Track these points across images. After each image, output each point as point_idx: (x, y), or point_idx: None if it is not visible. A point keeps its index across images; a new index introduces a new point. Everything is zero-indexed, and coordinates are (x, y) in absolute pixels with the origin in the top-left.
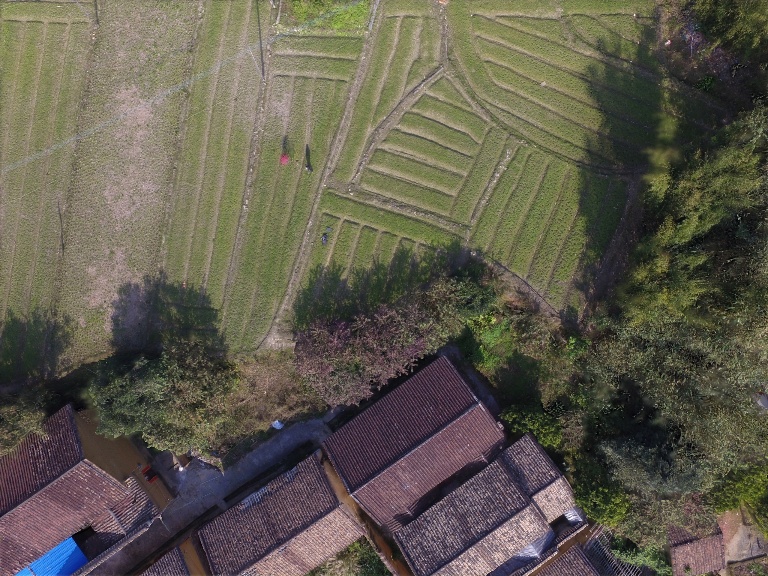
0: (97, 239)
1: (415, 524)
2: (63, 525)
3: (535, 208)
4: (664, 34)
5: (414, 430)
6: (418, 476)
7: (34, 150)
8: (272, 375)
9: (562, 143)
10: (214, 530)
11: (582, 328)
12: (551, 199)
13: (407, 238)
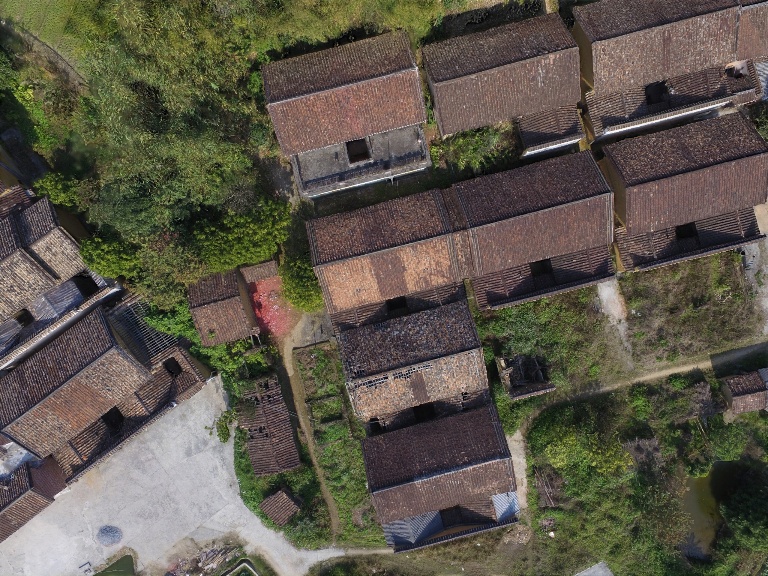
0: None
1: None
2: None
3: None
4: None
5: None
6: None
7: None
8: None
9: None
10: None
11: None
12: None
13: None
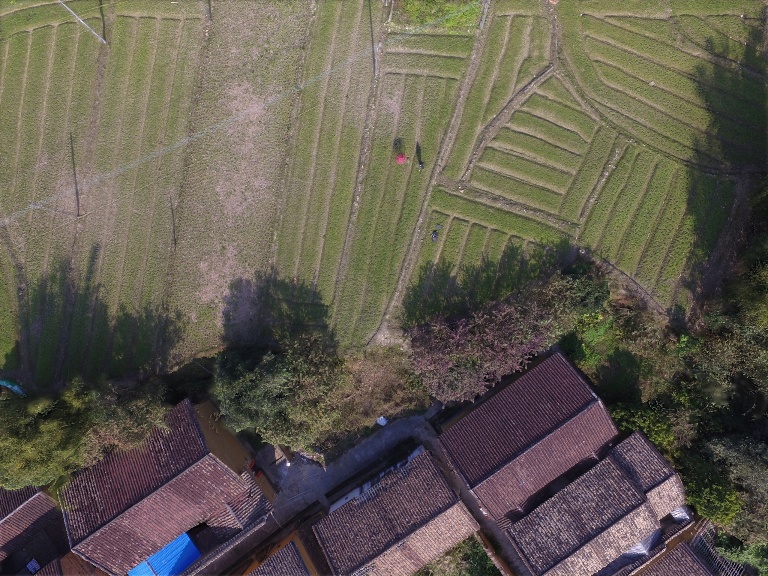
0: (209, 234)
1: (527, 520)
2: (183, 519)
3: (644, 207)
4: None
5: (532, 426)
6: (534, 472)
7: (147, 145)
8: (378, 371)
9: (670, 142)
10: (329, 525)
11: (690, 326)
12: (659, 198)
13: (516, 236)
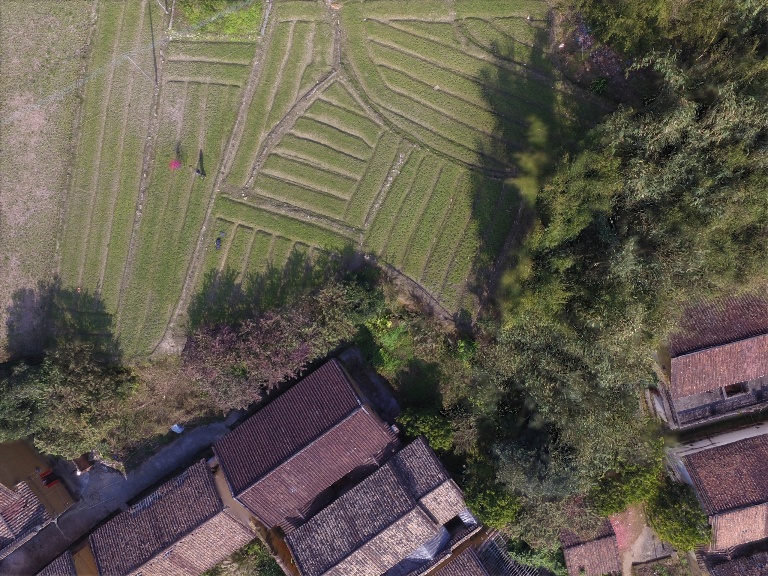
0: None
1: (306, 527)
2: None
3: (428, 212)
4: (558, 37)
5: (299, 434)
6: (305, 479)
7: None
8: (171, 379)
9: (455, 146)
10: (104, 534)
11: (475, 331)
12: (444, 202)
13: (301, 242)
